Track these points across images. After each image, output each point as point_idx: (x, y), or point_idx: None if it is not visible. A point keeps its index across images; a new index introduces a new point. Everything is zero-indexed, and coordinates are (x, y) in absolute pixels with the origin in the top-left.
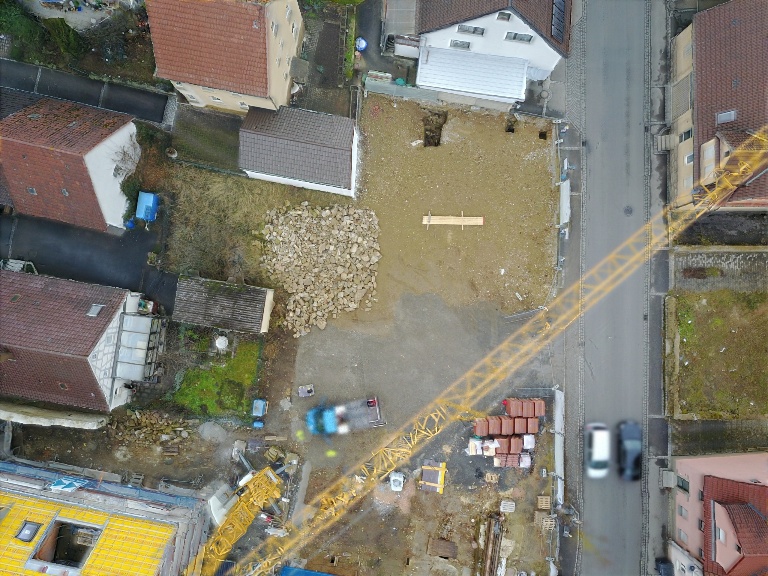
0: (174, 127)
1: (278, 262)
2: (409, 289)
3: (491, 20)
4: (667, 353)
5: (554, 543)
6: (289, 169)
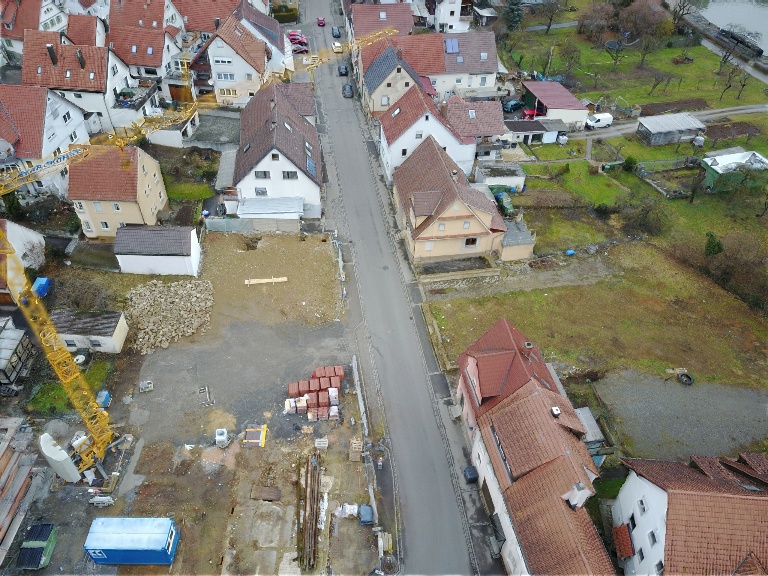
0: (73, 253)
1: (135, 310)
2: (235, 320)
3: (270, 162)
4: (431, 333)
5: (371, 476)
6: (148, 248)
